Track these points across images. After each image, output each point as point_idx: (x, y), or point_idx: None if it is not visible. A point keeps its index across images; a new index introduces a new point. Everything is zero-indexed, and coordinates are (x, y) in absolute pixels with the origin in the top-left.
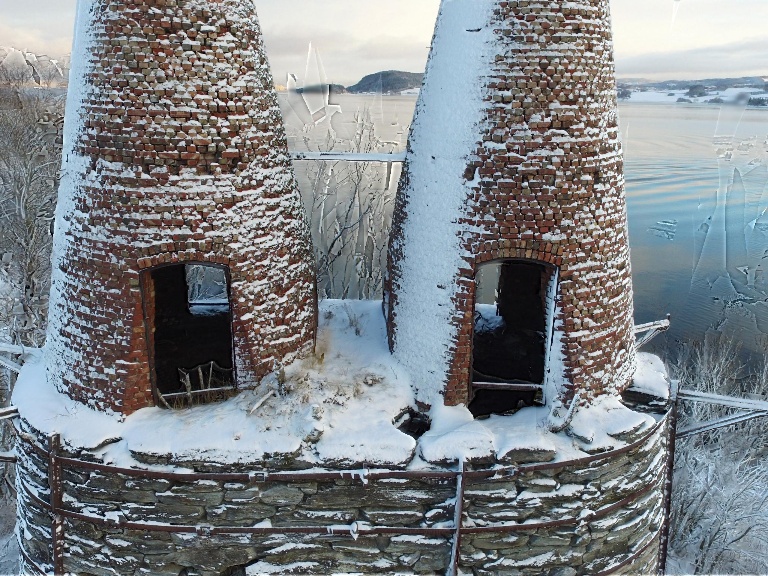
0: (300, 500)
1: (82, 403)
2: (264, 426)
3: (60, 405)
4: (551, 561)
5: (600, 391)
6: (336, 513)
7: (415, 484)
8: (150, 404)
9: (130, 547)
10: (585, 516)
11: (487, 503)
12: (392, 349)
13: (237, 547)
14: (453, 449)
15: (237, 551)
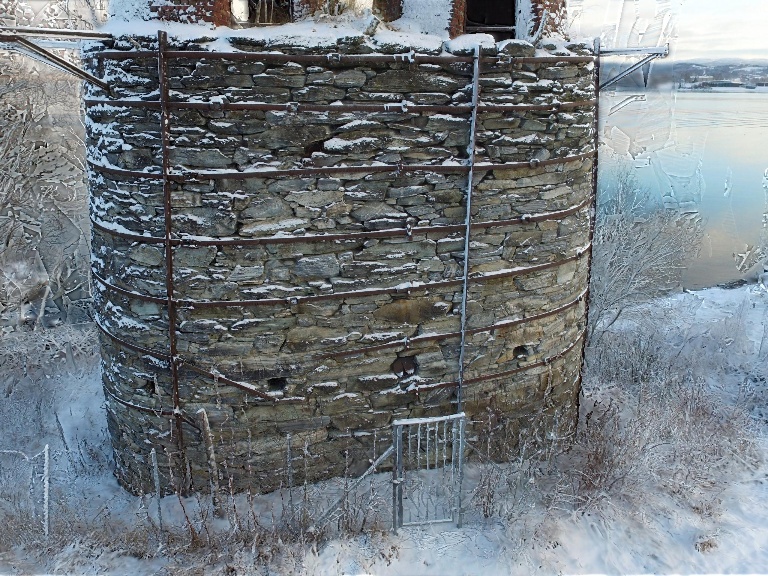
0: (364, 83)
1: (174, 21)
2: (333, 24)
3: (153, 25)
4: (535, 140)
5: (554, 29)
6: (390, 94)
7: (443, 73)
8: (229, 26)
9: (232, 127)
10: (556, 102)
11: (493, 88)
12: (401, 13)
13: (317, 126)
14: (470, 42)
15: (317, 128)
